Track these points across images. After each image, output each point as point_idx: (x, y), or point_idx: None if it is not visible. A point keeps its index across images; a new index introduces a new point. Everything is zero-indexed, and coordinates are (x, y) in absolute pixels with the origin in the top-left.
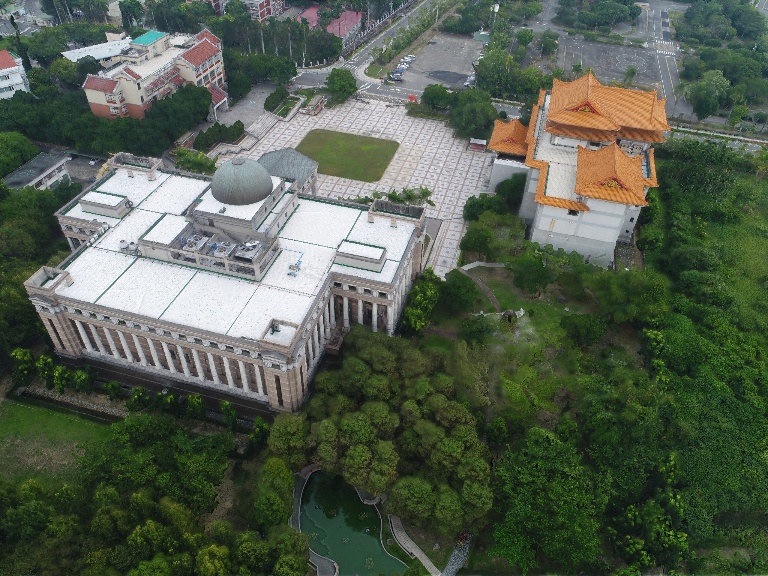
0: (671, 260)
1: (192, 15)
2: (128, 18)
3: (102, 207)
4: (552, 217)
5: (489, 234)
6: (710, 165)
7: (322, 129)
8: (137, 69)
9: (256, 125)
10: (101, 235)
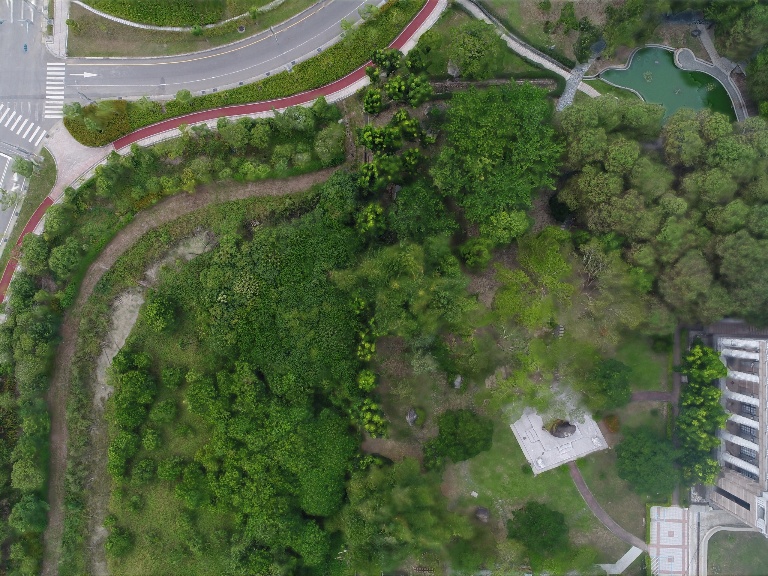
0: None
1: None
2: None
3: None
4: None
5: None
6: None
7: None
8: None
9: None
10: None
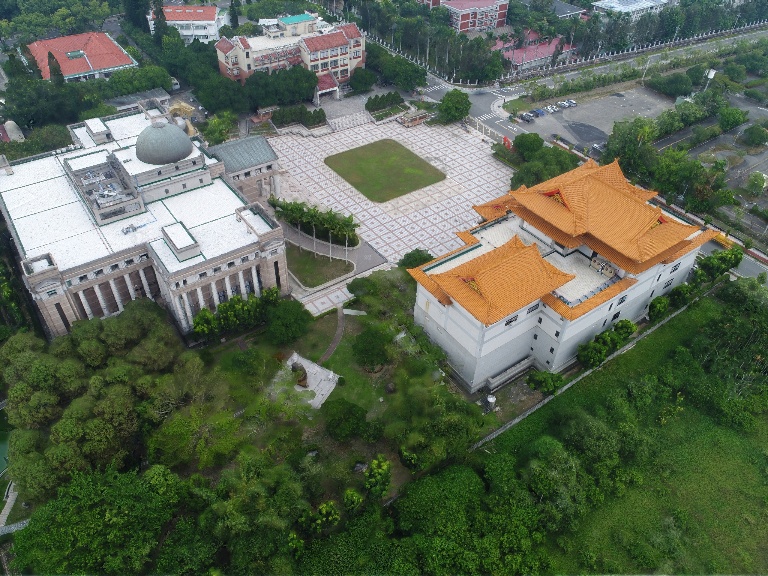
0: (565, 420)
1: (390, 11)
2: (347, 4)
3: (90, 131)
4: (427, 297)
5: (374, 287)
6: (762, 343)
7: (396, 141)
8: (267, 42)
9: (345, 119)
10: (70, 150)
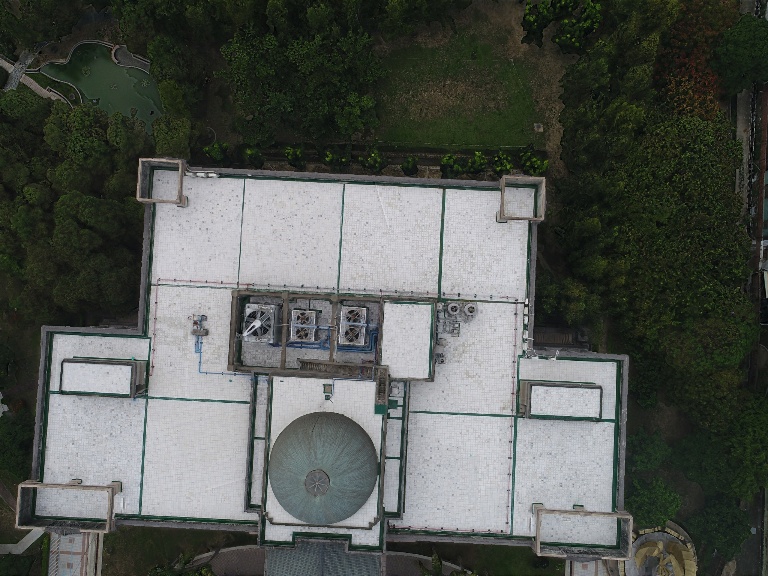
0: None
1: None
2: None
3: (555, 384)
4: None
5: None
6: None
7: None
8: None
9: None
10: None
